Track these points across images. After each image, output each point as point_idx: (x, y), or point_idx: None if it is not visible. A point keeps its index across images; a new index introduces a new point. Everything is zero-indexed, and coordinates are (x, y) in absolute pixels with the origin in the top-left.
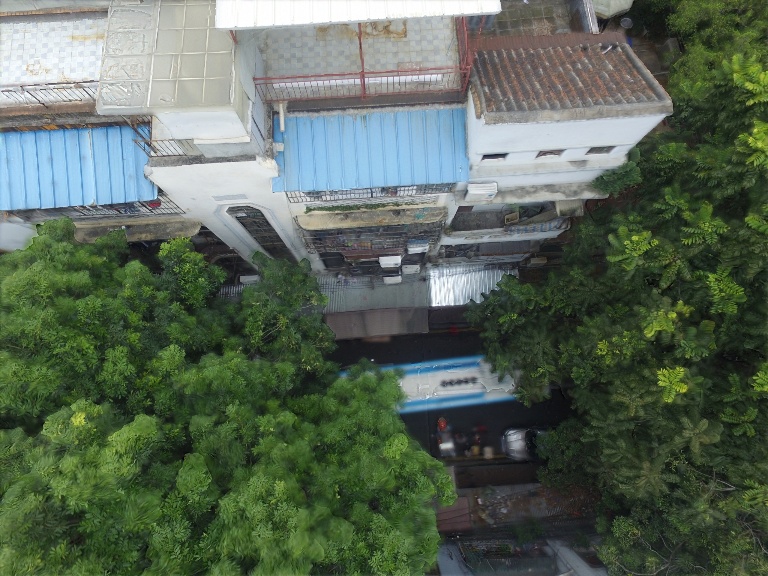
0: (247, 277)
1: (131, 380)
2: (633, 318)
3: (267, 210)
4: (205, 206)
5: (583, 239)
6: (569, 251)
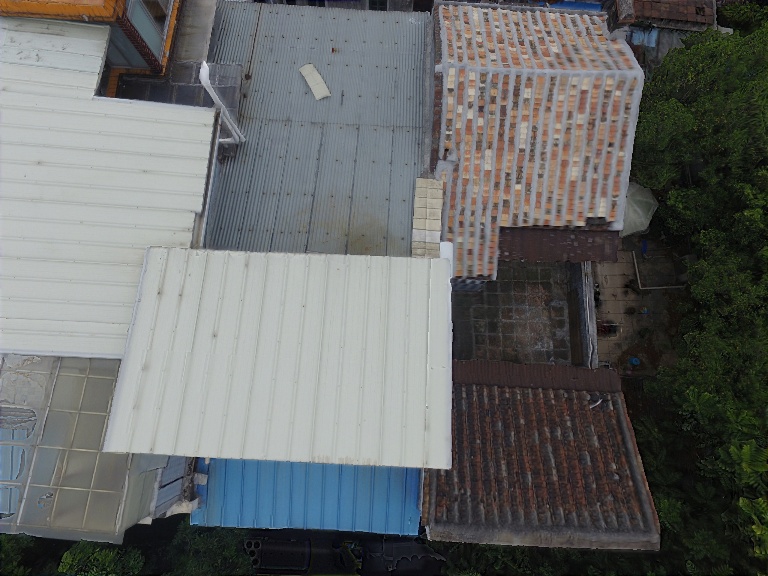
0: None
1: None
2: None
3: None
4: None
5: (555, 551)
6: None
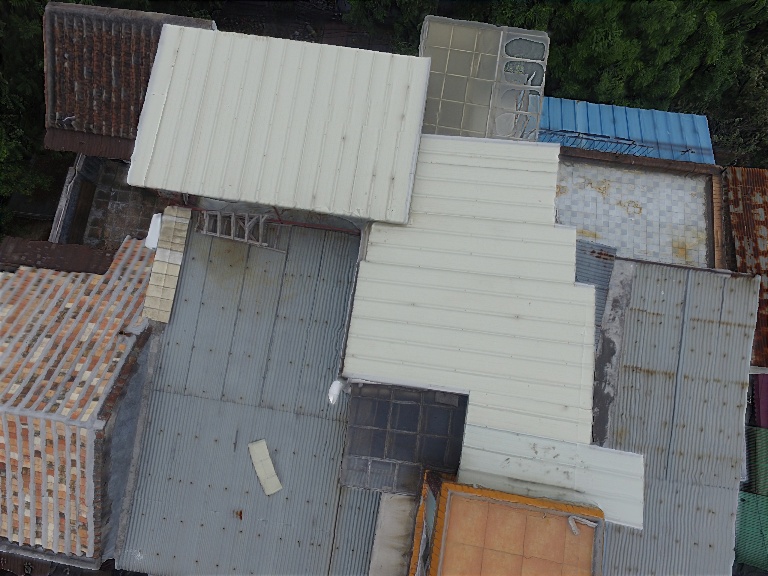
0: None
1: None
2: None
3: None
4: None
5: None
6: None
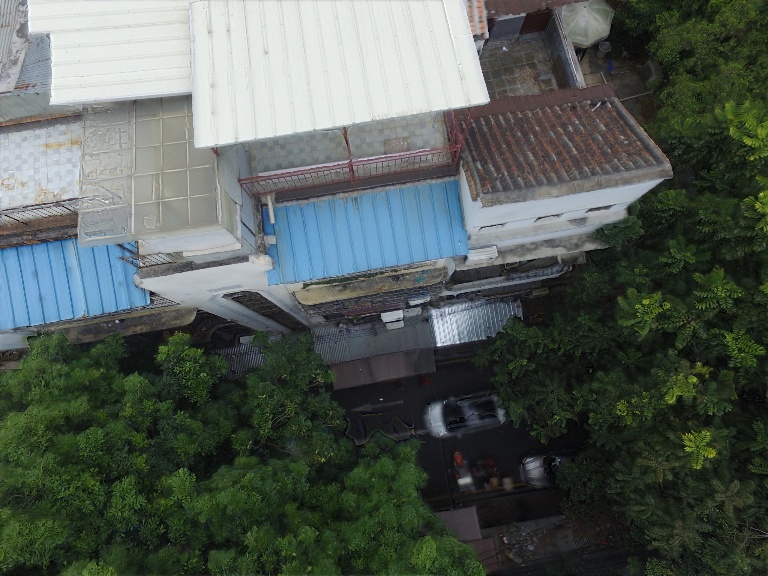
0: (247, 337)
1: (142, 508)
2: (650, 377)
3: (263, 291)
4: (199, 297)
5: (588, 288)
6: (573, 293)
